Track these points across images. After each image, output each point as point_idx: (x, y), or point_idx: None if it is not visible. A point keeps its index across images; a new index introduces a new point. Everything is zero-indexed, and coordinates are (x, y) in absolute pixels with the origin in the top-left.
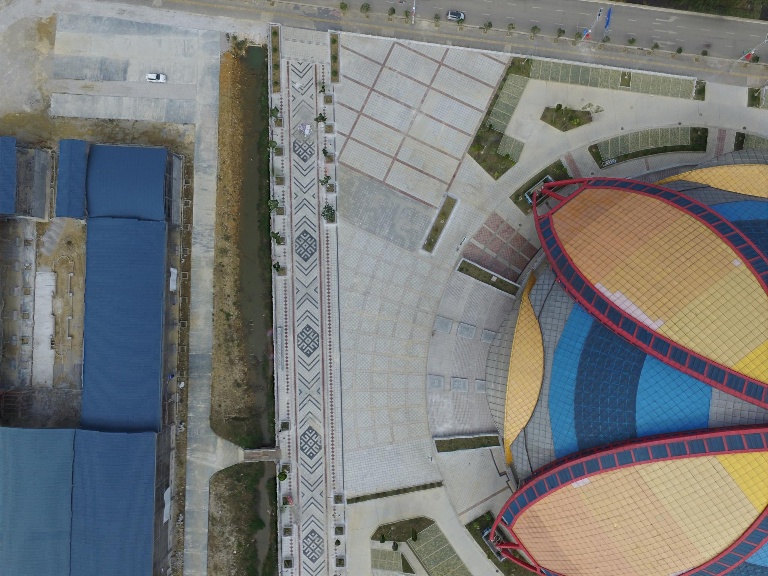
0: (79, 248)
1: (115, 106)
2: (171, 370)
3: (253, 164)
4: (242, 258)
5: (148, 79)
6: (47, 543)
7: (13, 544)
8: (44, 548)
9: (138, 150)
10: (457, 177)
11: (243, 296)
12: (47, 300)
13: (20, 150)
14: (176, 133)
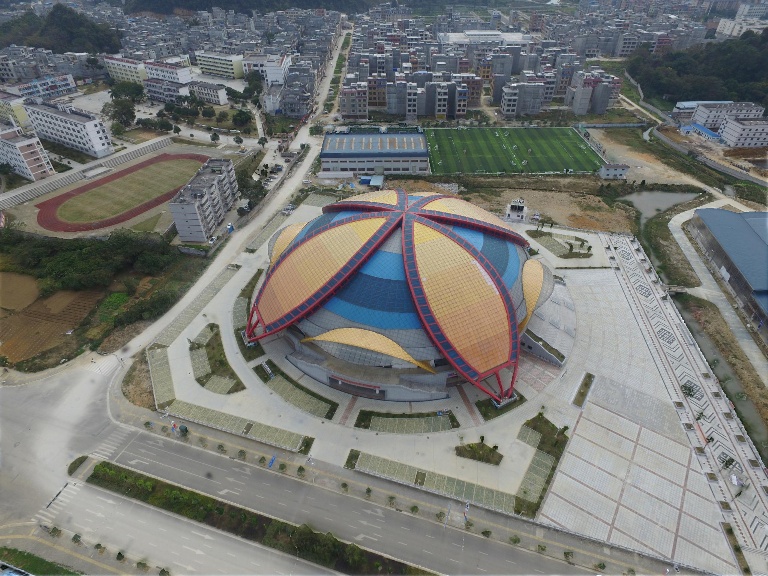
0: None
1: None
2: (763, 330)
3: None
4: None
5: None
6: None
7: None
8: None
9: None
10: (575, 421)
11: (730, 370)
12: None
13: None
14: None
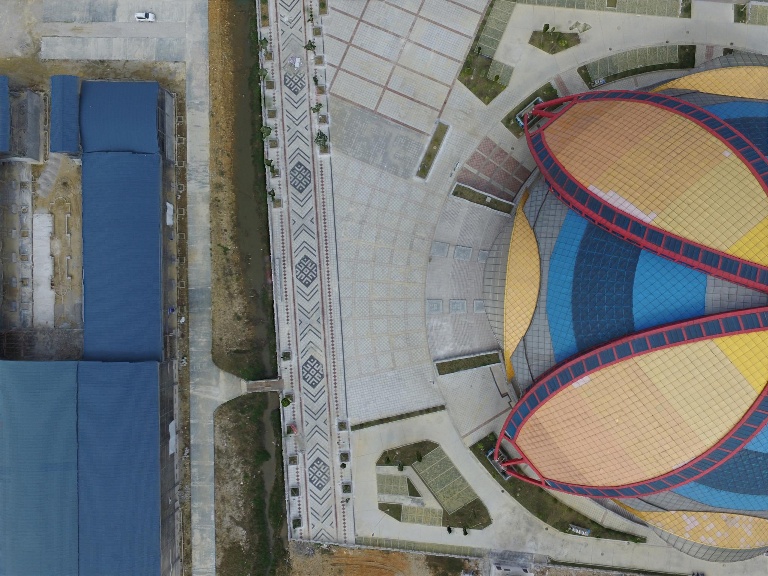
0: (75, 189)
1: (105, 47)
2: (171, 305)
3: (245, 100)
4: (237, 193)
5: (137, 18)
6: (54, 474)
7: (20, 476)
8: (51, 479)
9: (130, 84)
10: (448, 103)
11: (240, 231)
12: (45, 241)
13: (12, 93)
14: (167, 71)
